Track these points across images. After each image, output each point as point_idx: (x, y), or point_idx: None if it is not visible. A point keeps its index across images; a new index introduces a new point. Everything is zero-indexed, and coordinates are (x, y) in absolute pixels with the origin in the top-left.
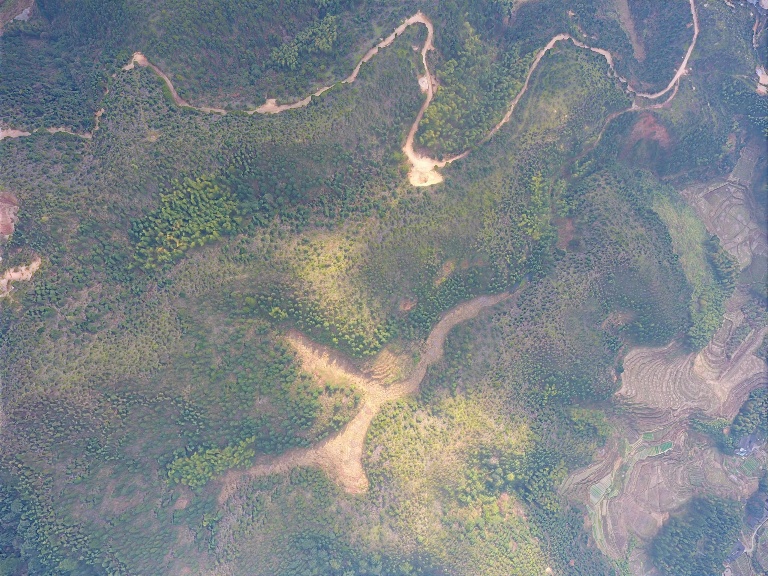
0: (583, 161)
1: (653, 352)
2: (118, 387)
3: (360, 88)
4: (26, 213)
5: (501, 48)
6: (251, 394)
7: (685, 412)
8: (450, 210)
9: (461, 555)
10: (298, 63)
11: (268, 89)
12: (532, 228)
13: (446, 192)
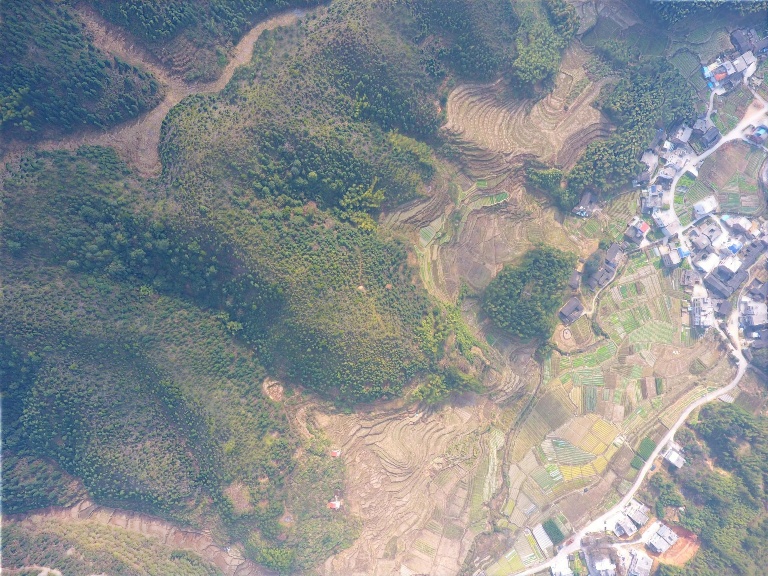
0: None
1: (481, 88)
2: None
3: None
4: None
5: None
6: (22, 40)
7: (519, 160)
8: None
9: (252, 237)
10: None
11: None
12: None
13: None
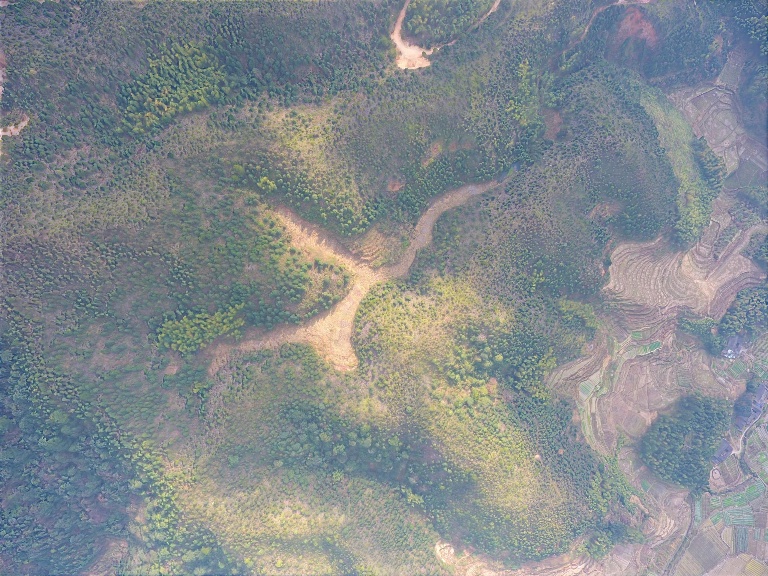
0: (570, 54)
1: (641, 247)
2: (107, 236)
3: None
4: (14, 69)
5: None
6: (240, 259)
7: (673, 311)
8: (437, 90)
9: (450, 430)
10: None
11: None
12: (519, 114)
13: (434, 74)
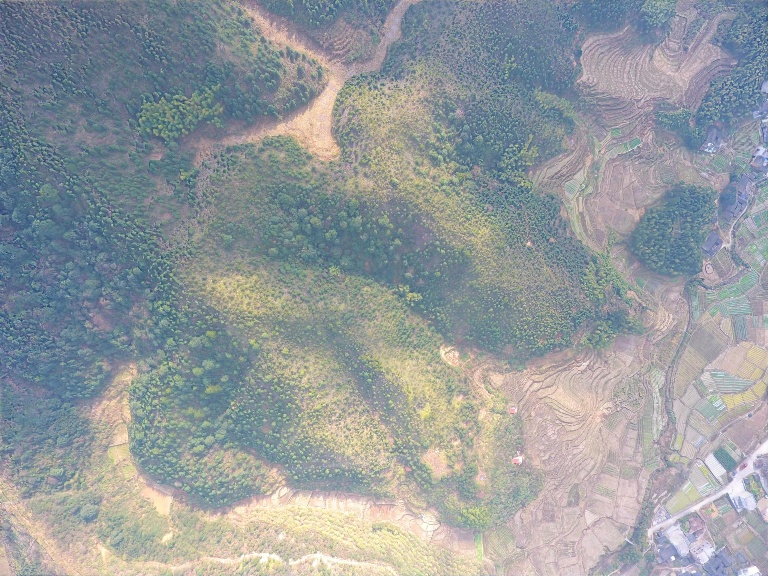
0: None
1: (610, 38)
2: (74, 1)
3: None
4: None
5: None
6: (211, 38)
7: (649, 104)
8: None
9: (438, 204)
10: None
11: None
12: None
13: None
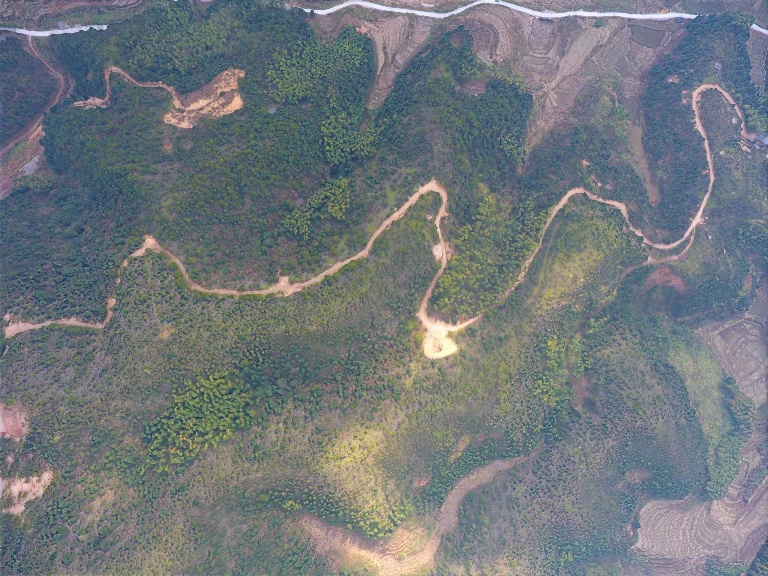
0: (598, 316)
1: (669, 504)
2: None
3: (374, 266)
4: (38, 428)
5: (514, 196)
6: None
7: (702, 559)
8: (465, 387)
9: None
10: (311, 232)
11: (281, 262)
12: (548, 394)
13: (461, 365)
